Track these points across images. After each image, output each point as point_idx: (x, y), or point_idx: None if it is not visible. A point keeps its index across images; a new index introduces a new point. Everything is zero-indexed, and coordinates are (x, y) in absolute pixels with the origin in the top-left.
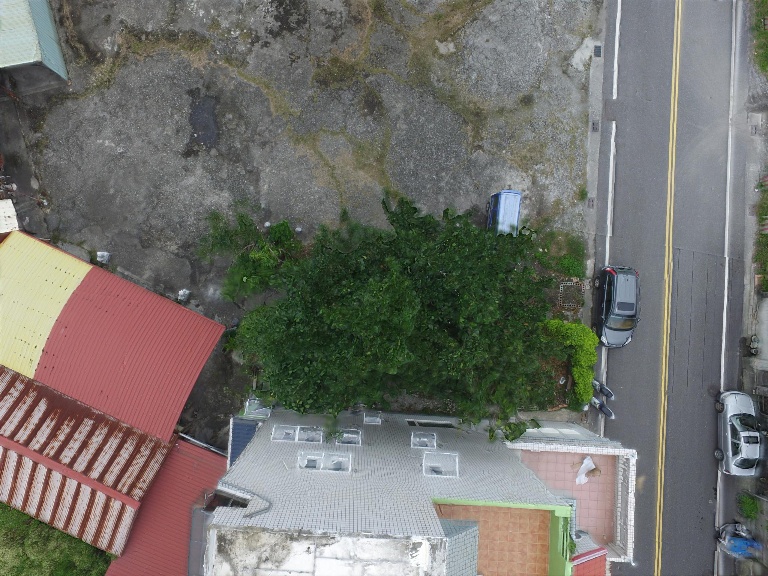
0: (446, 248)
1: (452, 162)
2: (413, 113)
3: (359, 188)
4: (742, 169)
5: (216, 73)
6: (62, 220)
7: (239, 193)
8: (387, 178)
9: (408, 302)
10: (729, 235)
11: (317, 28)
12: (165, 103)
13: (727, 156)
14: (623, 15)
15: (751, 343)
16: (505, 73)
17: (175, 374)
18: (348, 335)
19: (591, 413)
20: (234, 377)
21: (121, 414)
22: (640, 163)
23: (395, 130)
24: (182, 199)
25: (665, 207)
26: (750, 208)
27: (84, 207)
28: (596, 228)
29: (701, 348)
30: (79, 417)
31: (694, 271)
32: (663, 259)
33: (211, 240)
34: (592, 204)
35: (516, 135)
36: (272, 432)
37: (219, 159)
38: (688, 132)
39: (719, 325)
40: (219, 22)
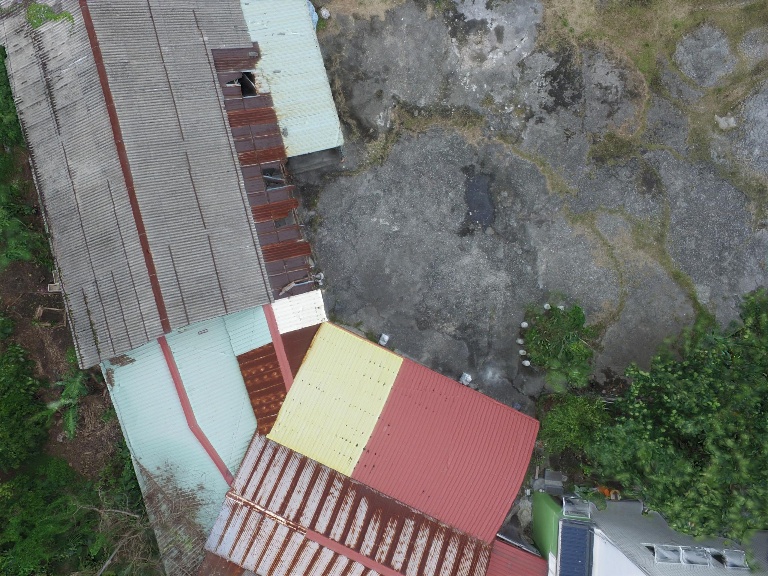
0: None
1: (735, 241)
2: (693, 191)
3: (640, 268)
4: None
5: (490, 149)
6: (337, 301)
7: (516, 273)
8: (669, 258)
9: None
10: None
11: (592, 103)
12: (439, 180)
13: None
14: None
15: None
16: None
17: (500, 475)
18: None
19: None
20: None
21: (441, 514)
22: None
23: (675, 208)
24: (458, 279)
25: None
26: None
27: (359, 287)
28: None
29: None
30: (400, 518)
31: None
32: None
33: (488, 322)
34: None
35: None
36: (655, 553)
37: (495, 238)
38: None
39: None
40: (492, 97)
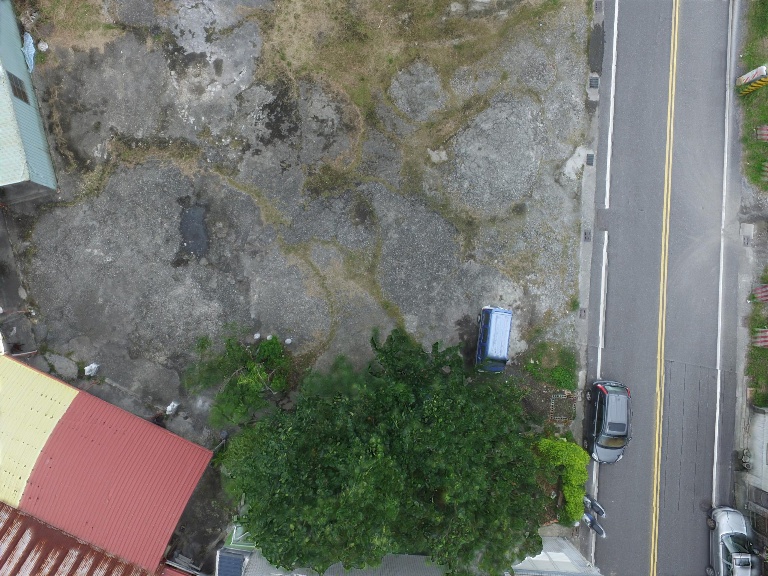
0: (432, 424)
1: (443, 272)
2: (404, 222)
3: (350, 298)
4: (734, 280)
5: (206, 181)
6: (50, 331)
7: (229, 303)
8: (378, 288)
9: (394, 480)
10: (721, 347)
11: (308, 136)
12: (155, 212)
13: (719, 267)
14: (615, 124)
15: (743, 457)
16: (497, 182)
17: (161, 506)
18: (334, 502)
19: (582, 528)
20: (222, 491)
21: (106, 545)
22: (632, 274)
23: (386, 239)
24: (171, 309)
25: (657, 319)
26: (742, 319)
27: (72, 317)
28: (588, 339)
29: (693, 462)
30: (63, 549)
31: (686, 384)
32: (655, 371)
33: (200, 351)
34: (584, 315)
35: (508, 245)
36: None
37: (209, 268)
38: (680, 243)
39: (711, 438)
40: (210, 129)
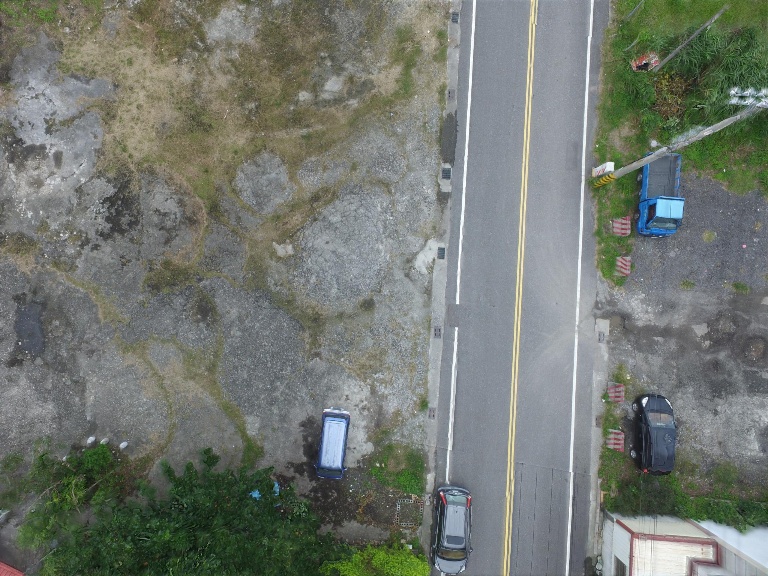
0: None
1: (288, 371)
2: (248, 319)
3: (190, 399)
4: (589, 378)
5: (43, 277)
6: None
7: (64, 405)
8: (219, 389)
9: None
10: (575, 448)
11: (150, 230)
12: None
13: (573, 365)
14: (467, 216)
15: (596, 563)
16: (345, 276)
17: None
18: None
19: None
20: None
21: None
22: (483, 372)
23: (229, 337)
24: (4, 411)
25: (508, 419)
26: (597, 419)
27: None
28: (437, 440)
29: (544, 569)
30: None
31: (537, 487)
32: (505, 475)
33: (33, 455)
34: (433, 414)
35: (355, 342)
36: None
37: (44, 368)
38: (533, 340)
39: (563, 544)
40: (48, 224)
